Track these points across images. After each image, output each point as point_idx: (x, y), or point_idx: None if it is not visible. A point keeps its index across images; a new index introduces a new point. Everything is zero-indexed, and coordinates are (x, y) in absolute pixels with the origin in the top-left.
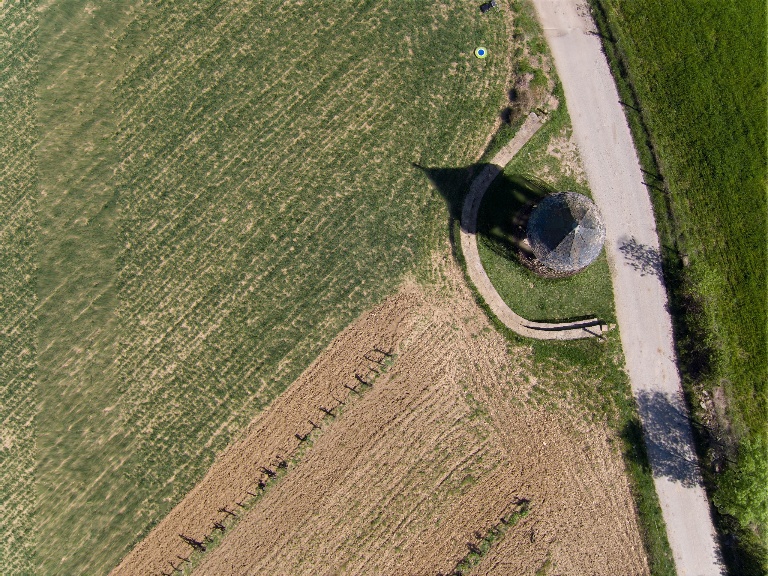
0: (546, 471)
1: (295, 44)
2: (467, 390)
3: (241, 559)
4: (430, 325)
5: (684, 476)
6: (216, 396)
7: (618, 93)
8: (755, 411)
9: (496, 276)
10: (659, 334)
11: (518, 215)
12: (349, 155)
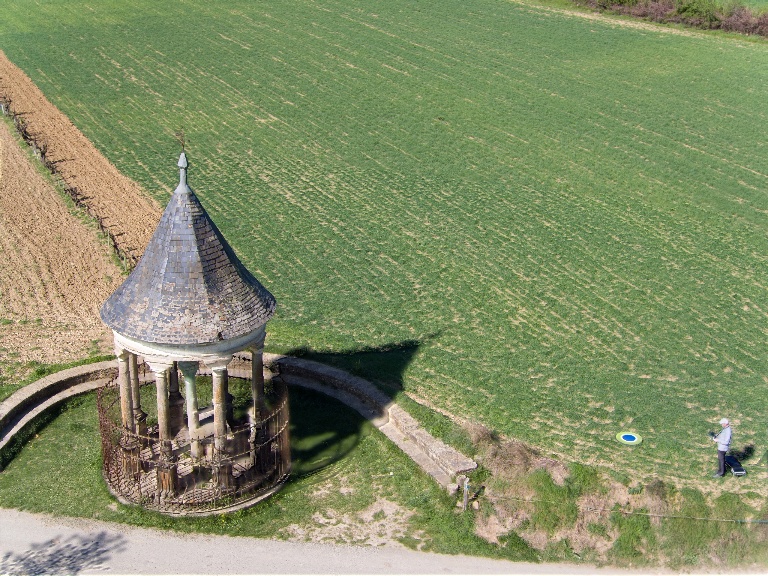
0: None
1: None
2: None
3: (6, 179)
4: None
5: None
6: None
7: None
8: None
9: None
10: None
11: None
12: None
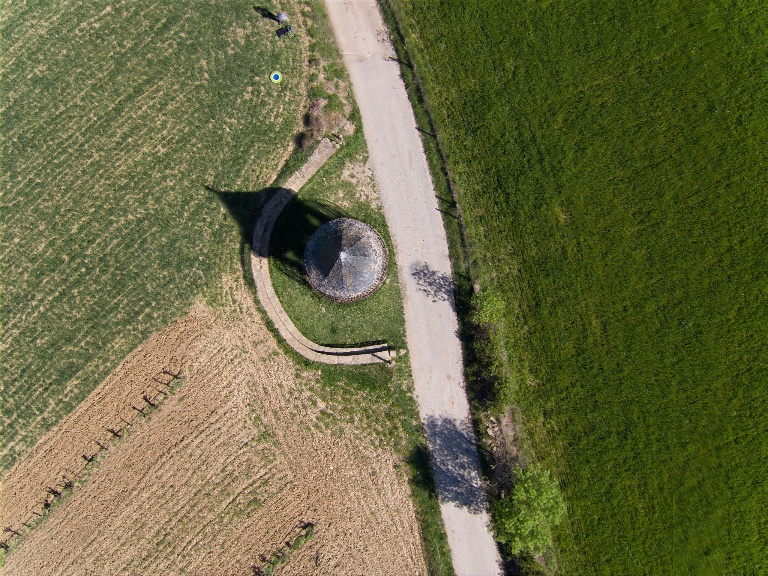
0: (332, 495)
1: (91, 66)
2: (255, 413)
3: None
4: (220, 348)
5: (471, 502)
6: (4, 416)
7: (415, 119)
8: (544, 438)
9: (288, 300)
10: (449, 360)
11: None
12: (142, 177)
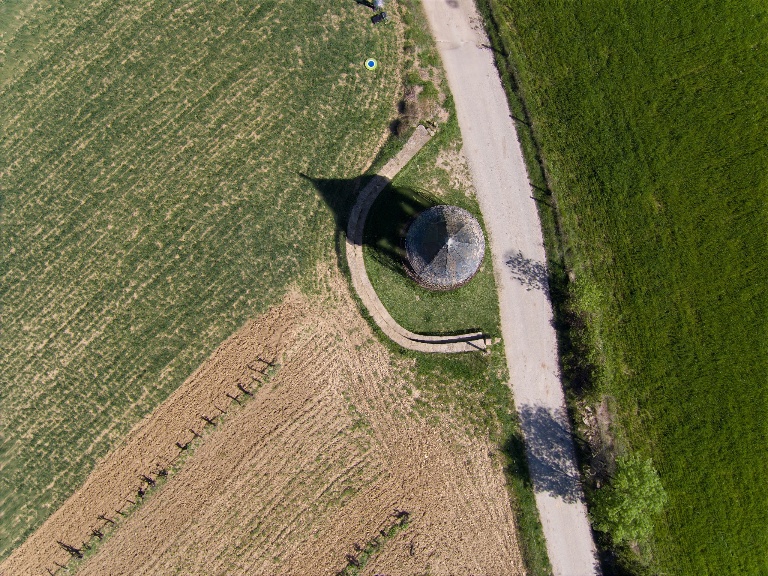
0: (427, 484)
1: (185, 52)
2: (350, 401)
3: (119, 567)
4: (314, 336)
5: (565, 492)
6: (97, 403)
7: (509, 107)
8: (638, 428)
9: (382, 288)
10: (544, 349)
11: (405, 227)
12: (236, 164)
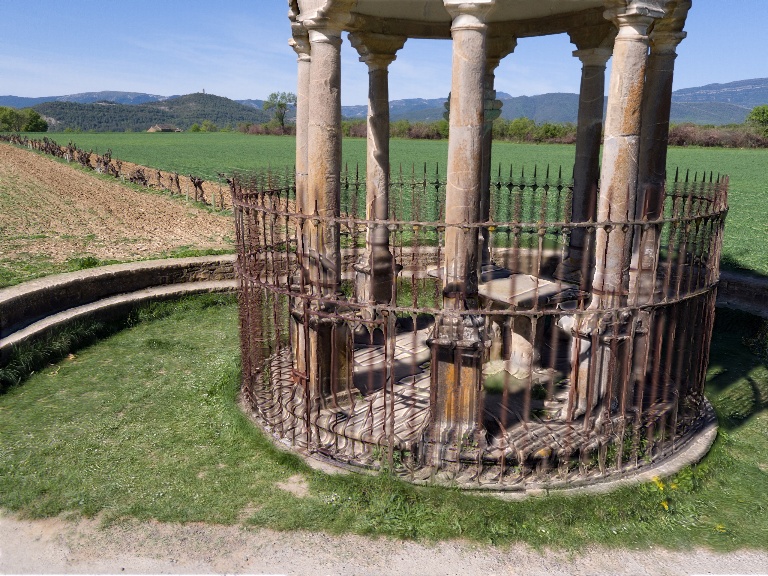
0: None
1: None
2: None
3: None
4: None
5: None
6: None
7: None
8: None
9: None
10: None
11: None
12: None
